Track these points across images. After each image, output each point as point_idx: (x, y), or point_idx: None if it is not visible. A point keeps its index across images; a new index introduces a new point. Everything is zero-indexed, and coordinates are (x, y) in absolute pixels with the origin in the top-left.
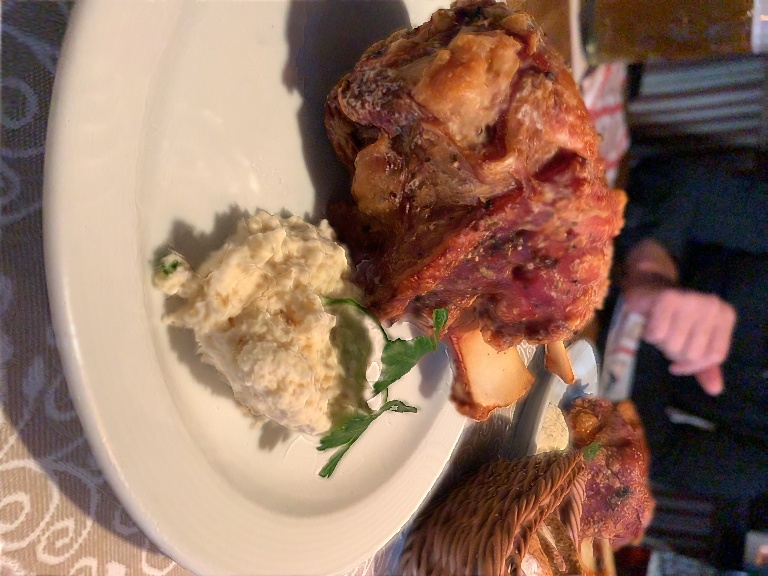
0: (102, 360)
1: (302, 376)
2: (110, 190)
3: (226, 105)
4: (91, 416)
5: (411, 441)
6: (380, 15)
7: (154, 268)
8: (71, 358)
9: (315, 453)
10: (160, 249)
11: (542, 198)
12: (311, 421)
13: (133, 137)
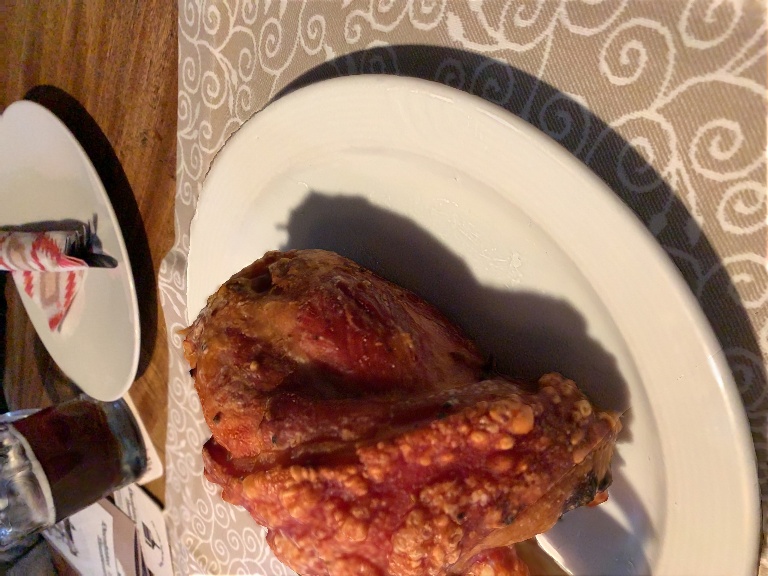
0: None
1: None
2: None
3: None
4: None
5: None
6: (338, 232)
7: None
8: None
9: None
10: None
11: None
12: None
13: None
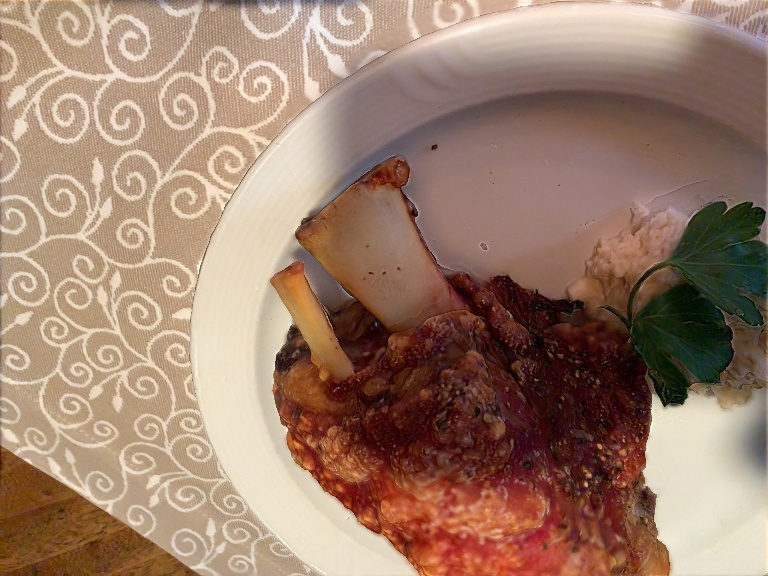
0: None
1: None
2: None
3: (699, 452)
4: None
5: (466, 115)
6: None
7: None
8: None
9: (650, 162)
10: None
11: (624, 554)
12: None
13: None
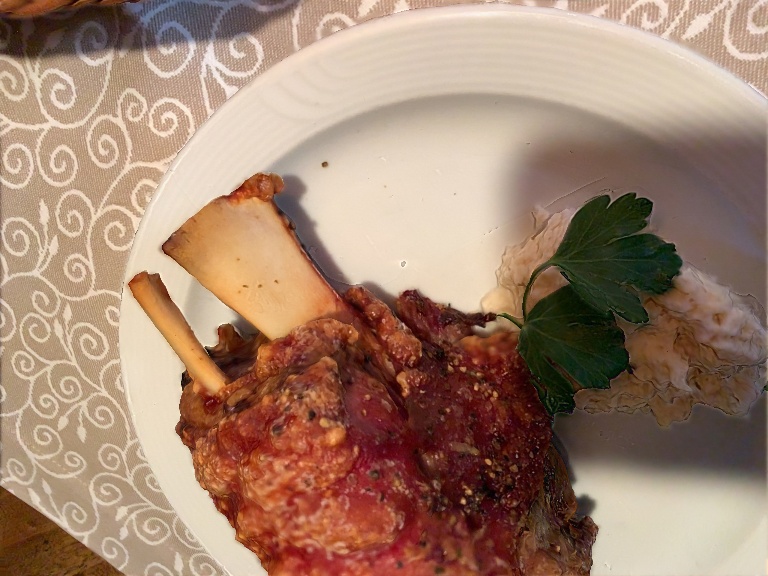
0: None
1: (735, 347)
2: None
3: (660, 481)
4: None
5: (345, 130)
6: None
7: None
8: None
9: (543, 163)
10: None
11: None
12: (703, 289)
13: None
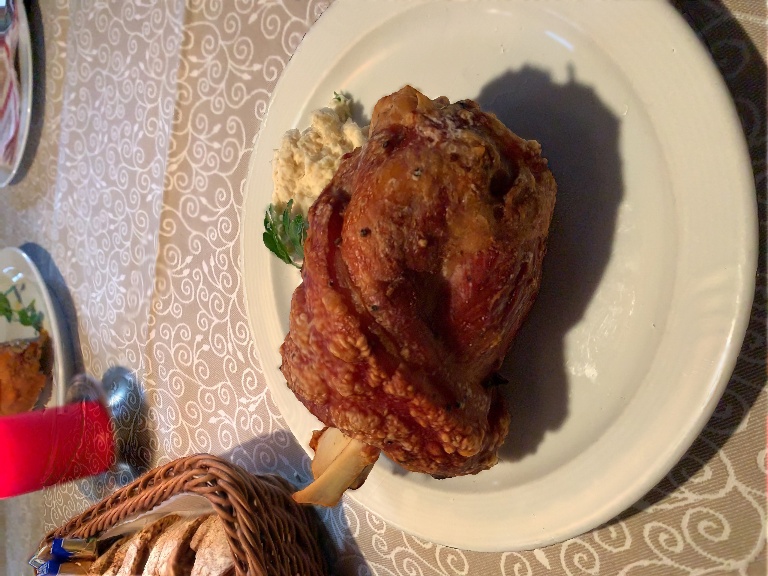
0: None
1: None
2: (334, 37)
3: None
4: (276, 88)
5: None
6: (581, 161)
7: (337, 93)
8: (288, 66)
9: None
10: (349, 95)
11: None
12: None
13: (355, 31)
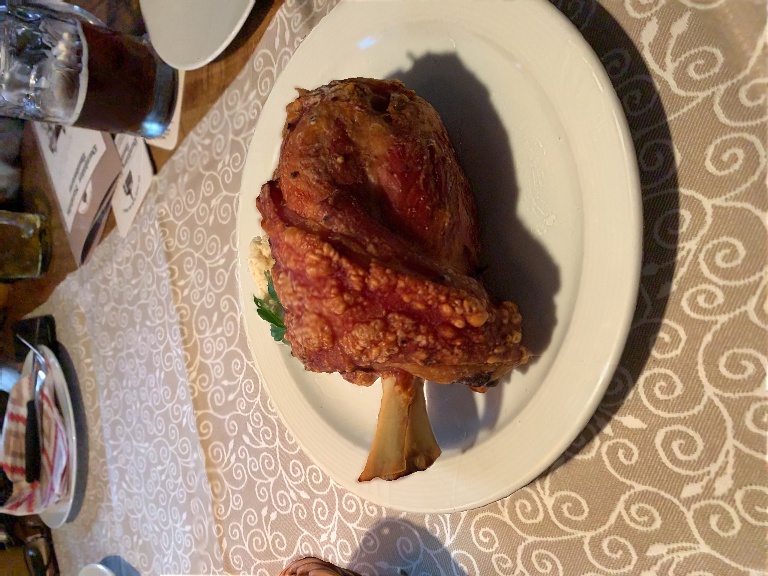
0: (244, 217)
1: None
2: (259, 165)
3: None
4: (237, 231)
5: None
6: (450, 97)
7: None
8: None
9: None
10: None
11: None
12: None
13: (271, 150)
